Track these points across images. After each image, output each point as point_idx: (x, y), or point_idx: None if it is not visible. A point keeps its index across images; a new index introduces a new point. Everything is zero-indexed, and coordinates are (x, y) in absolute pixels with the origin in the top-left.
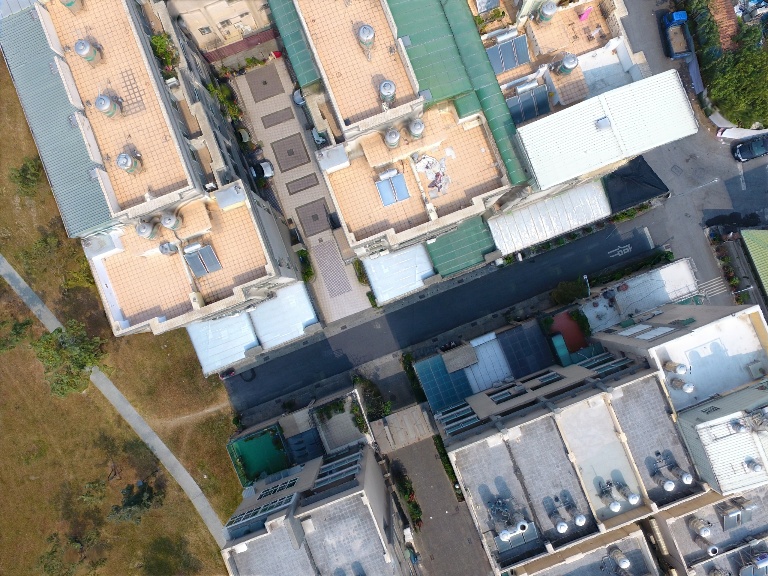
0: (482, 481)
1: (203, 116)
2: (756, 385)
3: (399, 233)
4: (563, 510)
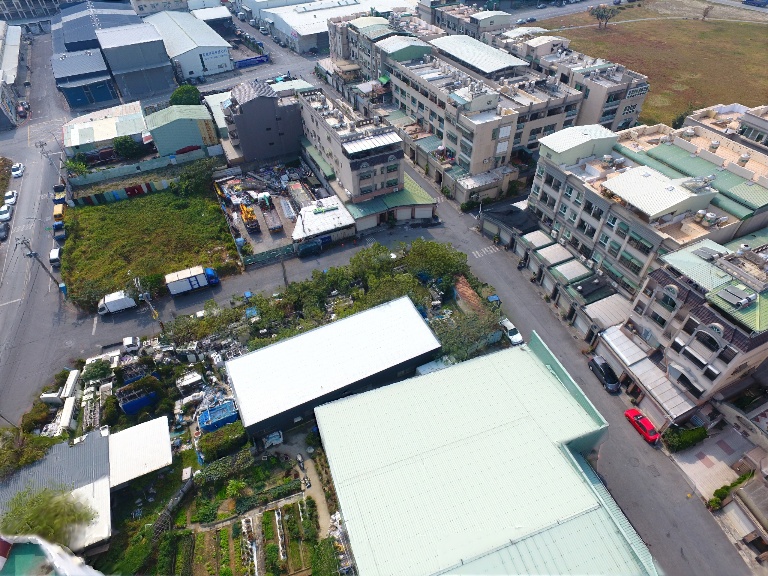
0: (563, 94)
1: (766, 147)
2: (468, 113)
3: (644, 127)
4: (529, 91)
